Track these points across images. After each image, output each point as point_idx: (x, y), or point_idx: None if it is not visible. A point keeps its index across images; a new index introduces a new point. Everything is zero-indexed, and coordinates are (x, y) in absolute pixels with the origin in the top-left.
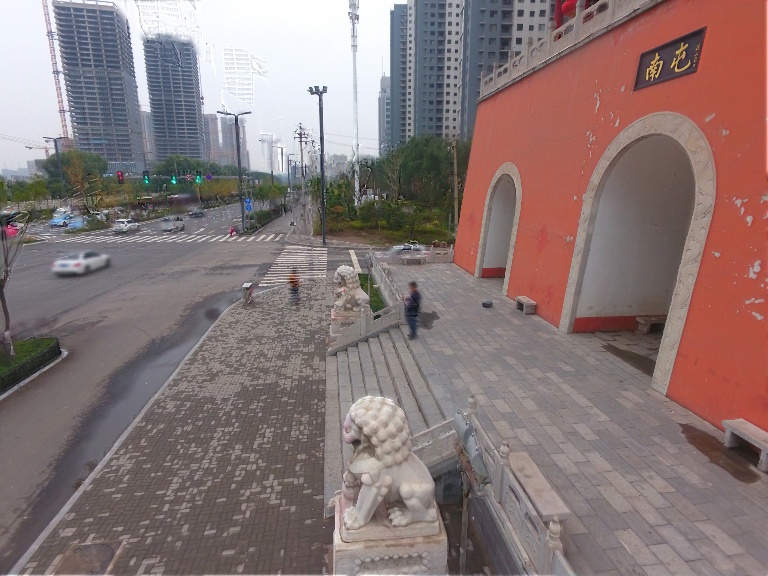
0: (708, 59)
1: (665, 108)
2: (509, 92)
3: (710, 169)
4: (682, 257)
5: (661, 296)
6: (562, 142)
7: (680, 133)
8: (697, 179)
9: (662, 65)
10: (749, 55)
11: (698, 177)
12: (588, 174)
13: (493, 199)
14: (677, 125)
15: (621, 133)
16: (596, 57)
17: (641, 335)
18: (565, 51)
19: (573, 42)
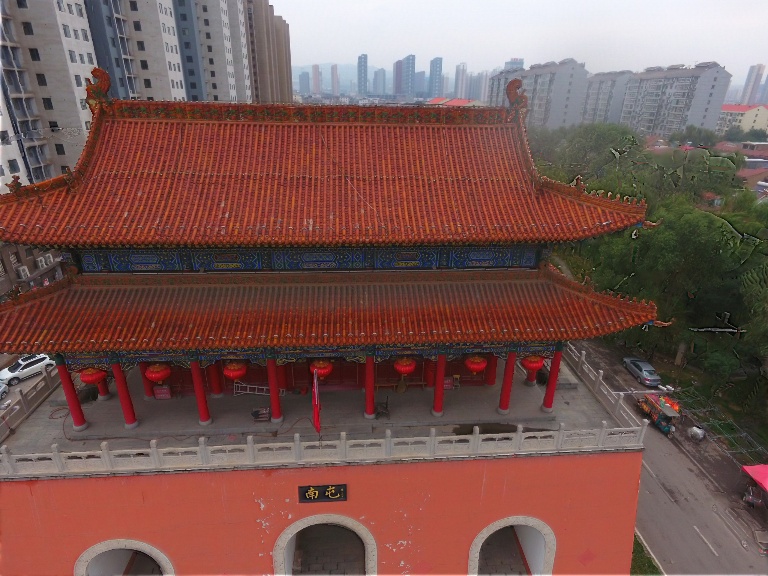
0: (351, 496)
1: (330, 512)
2: (76, 483)
3: (370, 536)
4: (366, 567)
5: (293, 545)
6: (224, 525)
7: (346, 523)
8: (364, 540)
9: (318, 493)
10: (375, 499)
11: (364, 539)
12: (270, 542)
13: (88, 567)
14: (342, 520)
15: (297, 522)
16: (245, 479)
17: (302, 574)
18: (198, 471)
19: (203, 464)
